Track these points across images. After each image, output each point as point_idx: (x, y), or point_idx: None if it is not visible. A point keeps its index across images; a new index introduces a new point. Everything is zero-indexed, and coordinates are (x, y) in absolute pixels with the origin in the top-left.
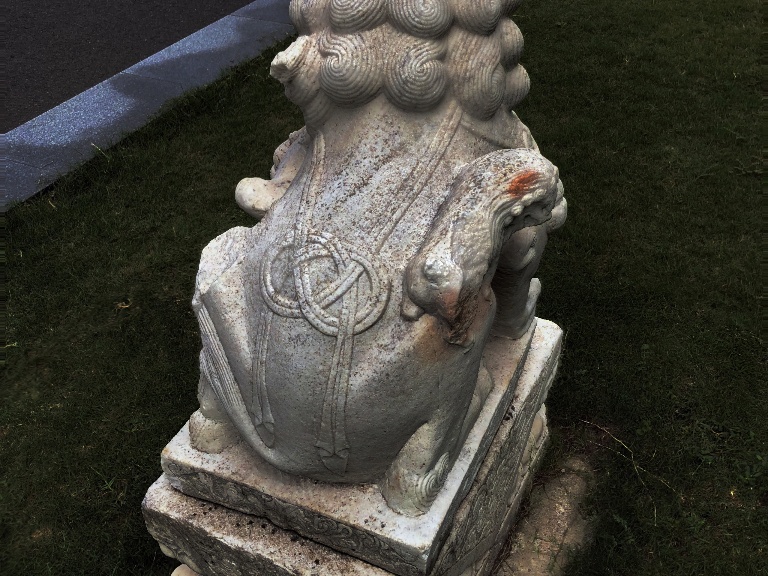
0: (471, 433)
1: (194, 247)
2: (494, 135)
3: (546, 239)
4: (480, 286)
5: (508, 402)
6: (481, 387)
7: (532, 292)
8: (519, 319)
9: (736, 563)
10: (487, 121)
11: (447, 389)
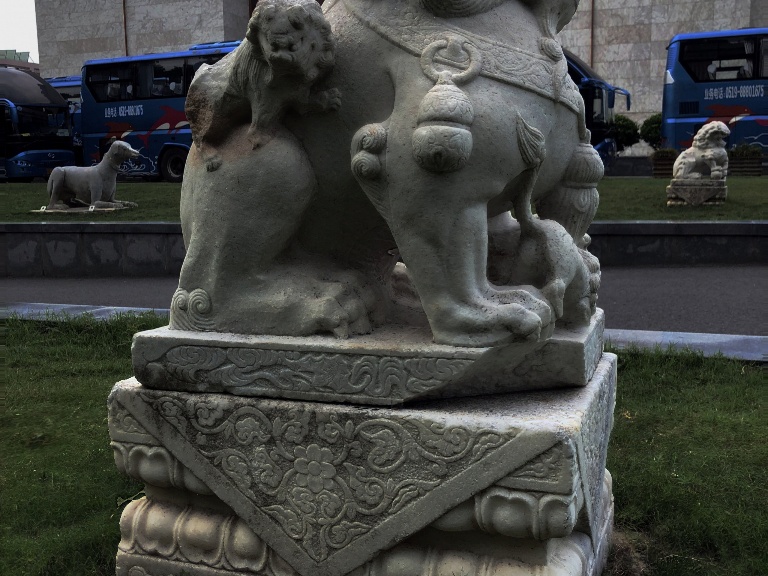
0: (271, 336)
1: (760, 427)
2: (367, 15)
3: (422, 174)
4: (217, 100)
5: (370, 391)
6: (307, 304)
7: (494, 308)
8: (430, 305)
9: None
10: (367, 0)
11: (197, 203)
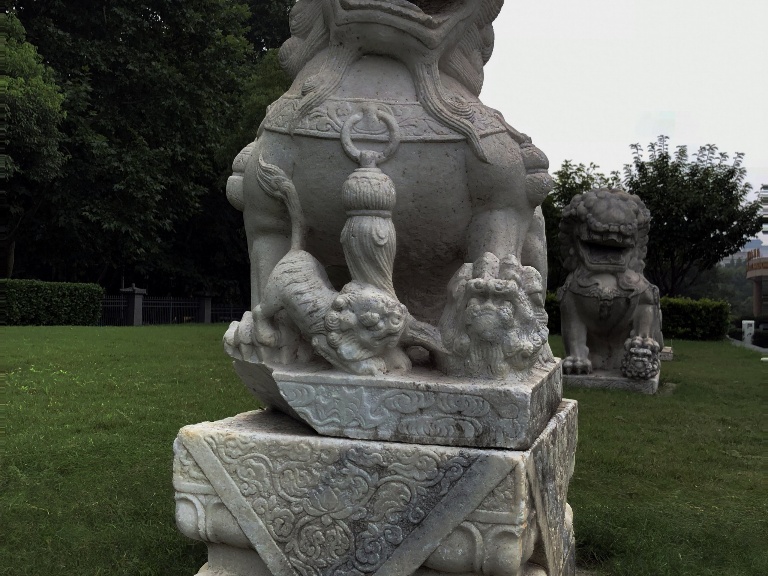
0: None
1: None
2: None
3: None
4: None
5: None
6: None
7: None
8: None
9: (18, 568)
10: None
11: None
